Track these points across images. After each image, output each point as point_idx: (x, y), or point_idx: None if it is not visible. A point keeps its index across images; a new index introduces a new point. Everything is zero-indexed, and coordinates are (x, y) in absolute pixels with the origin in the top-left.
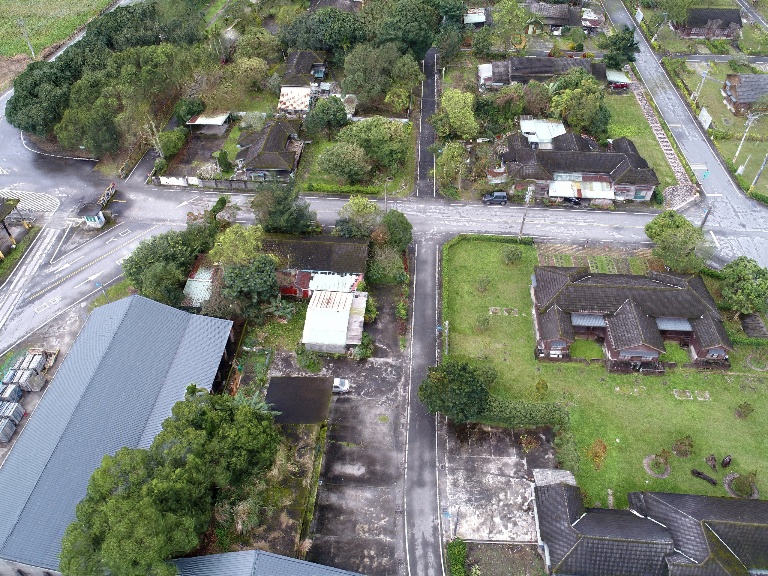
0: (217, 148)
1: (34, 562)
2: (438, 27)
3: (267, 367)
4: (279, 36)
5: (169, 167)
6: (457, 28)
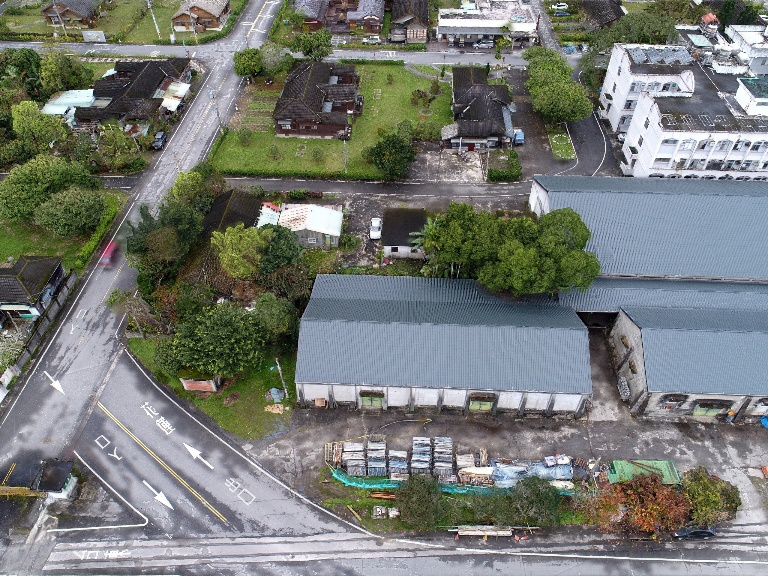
0: None
1: (578, 319)
2: None
3: None
4: None
5: None
6: None
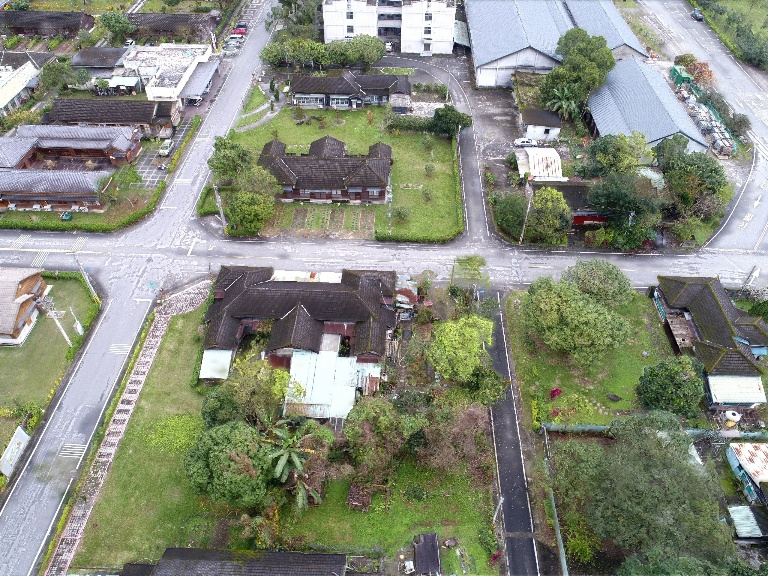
0: None
1: None
2: None
3: None
4: None
5: None
6: None
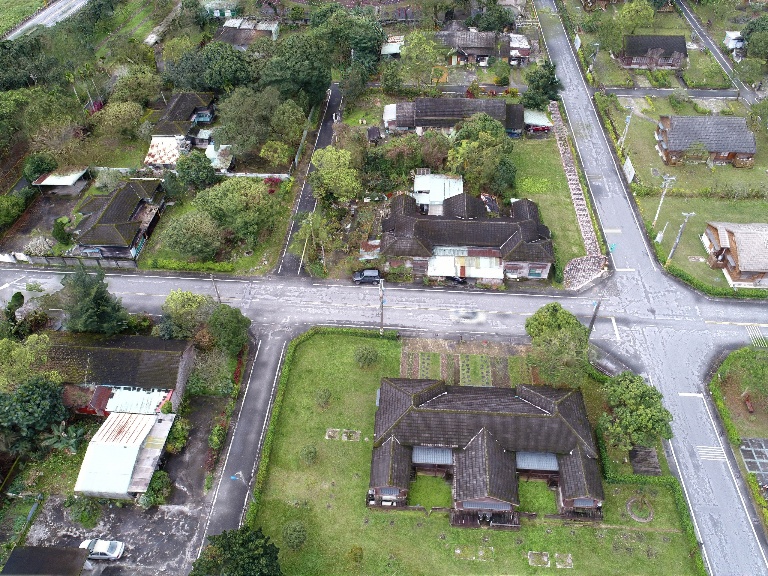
0: (65, 212)
1: None
2: (349, 60)
3: (30, 521)
4: (165, 74)
5: (2, 238)
6: (370, 61)
